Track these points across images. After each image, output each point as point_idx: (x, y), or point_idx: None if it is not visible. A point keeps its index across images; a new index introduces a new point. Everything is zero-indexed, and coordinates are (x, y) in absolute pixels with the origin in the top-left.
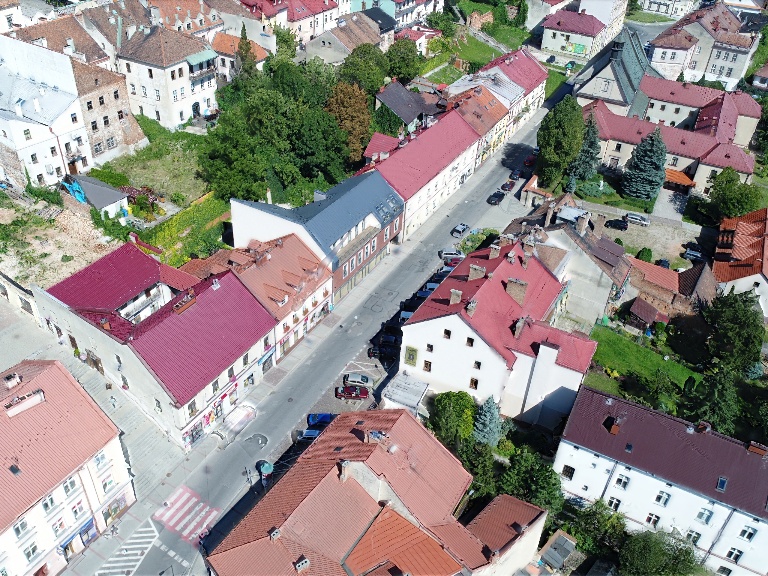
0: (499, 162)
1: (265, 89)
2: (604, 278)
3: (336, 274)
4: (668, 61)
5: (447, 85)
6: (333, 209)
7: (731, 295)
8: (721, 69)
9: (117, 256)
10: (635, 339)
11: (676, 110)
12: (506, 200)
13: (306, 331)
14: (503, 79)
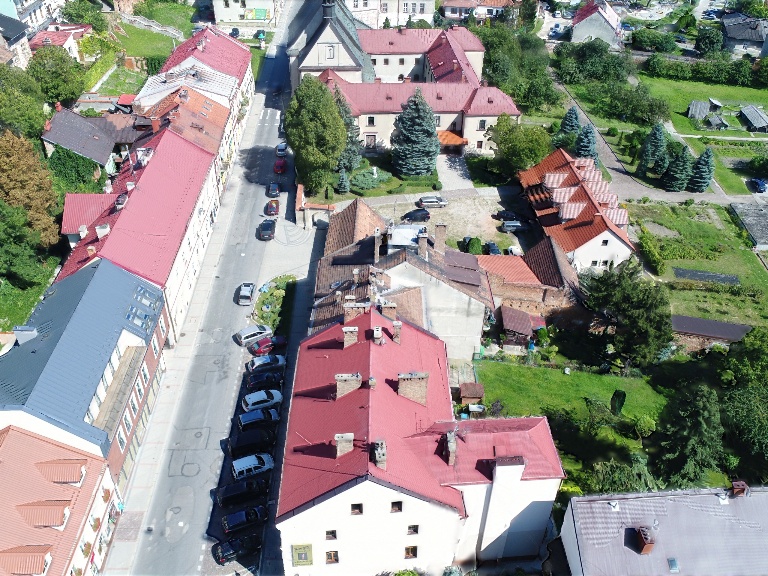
0: (243, 179)
1: None
2: (473, 305)
3: (110, 456)
4: (362, 9)
5: (130, 95)
6: (62, 354)
7: (612, 272)
8: (413, 7)
9: None
10: (523, 361)
11: (400, 61)
12: (279, 228)
13: (97, 571)
14: (205, 71)
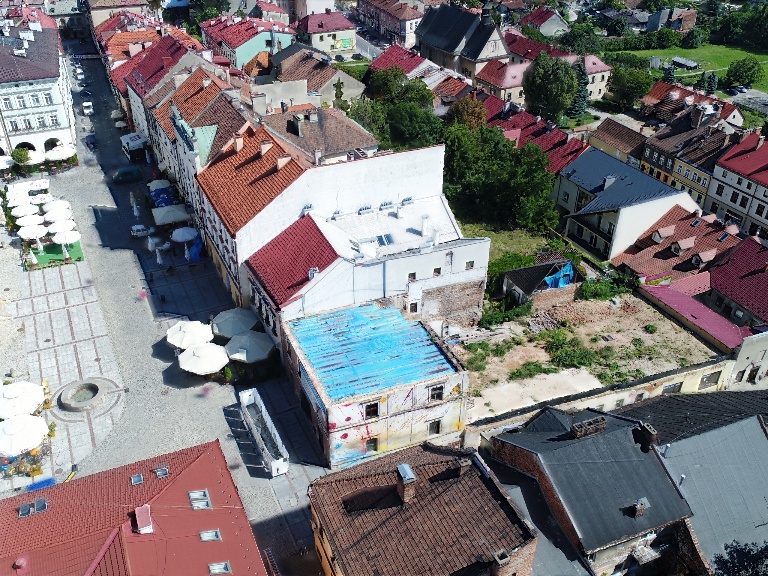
0: None
1: (386, 141)
2: None
3: None
4: None
5: None
6: None
7: None
8: None
9: (663, 299)
10: None
11: None
12: None
13: None
14: None
